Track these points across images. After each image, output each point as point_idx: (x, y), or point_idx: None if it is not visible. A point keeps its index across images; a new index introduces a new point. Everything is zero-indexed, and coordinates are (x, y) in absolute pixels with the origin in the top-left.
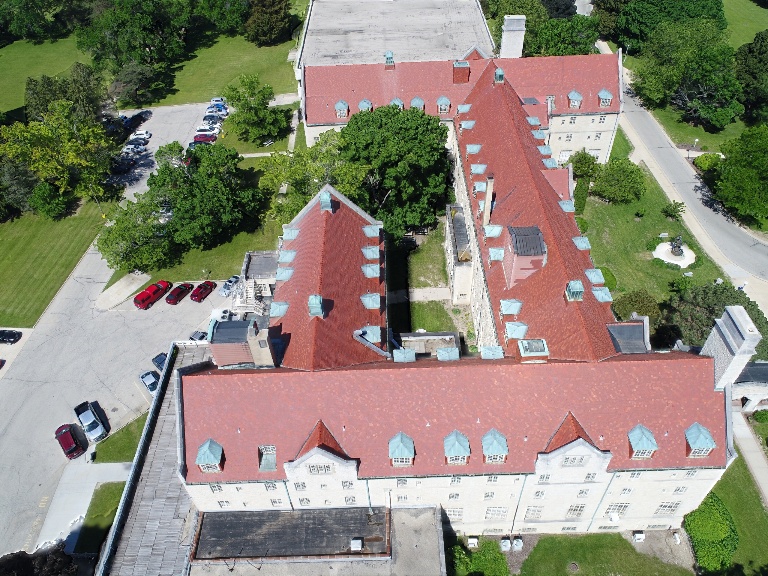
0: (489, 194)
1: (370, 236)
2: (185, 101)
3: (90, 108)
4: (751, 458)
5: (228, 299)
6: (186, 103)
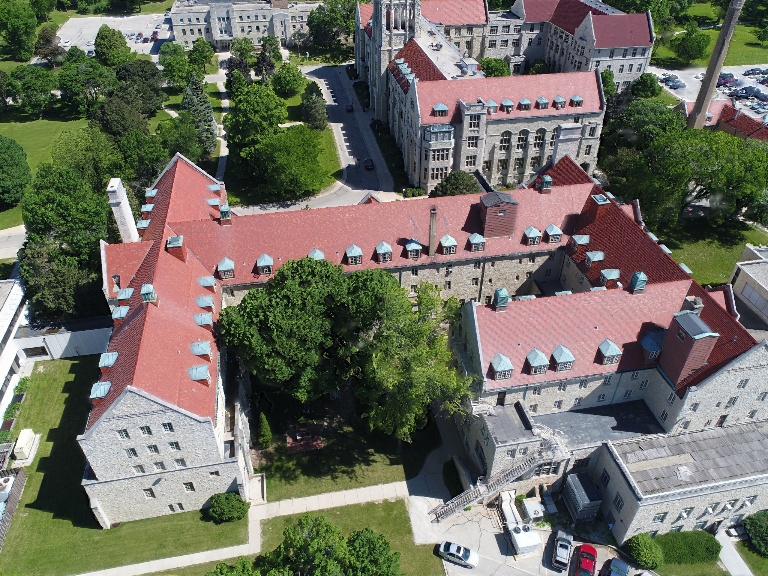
0: None
1: None
2: None
3: None
4: None
5: (479, 554)
6: None
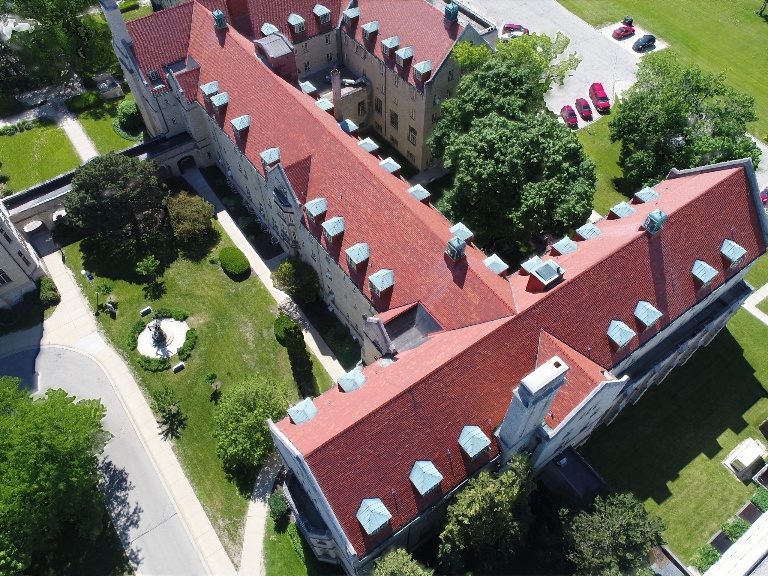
0: None
1: None
2: None
3: None
4: None
5: None
6: None
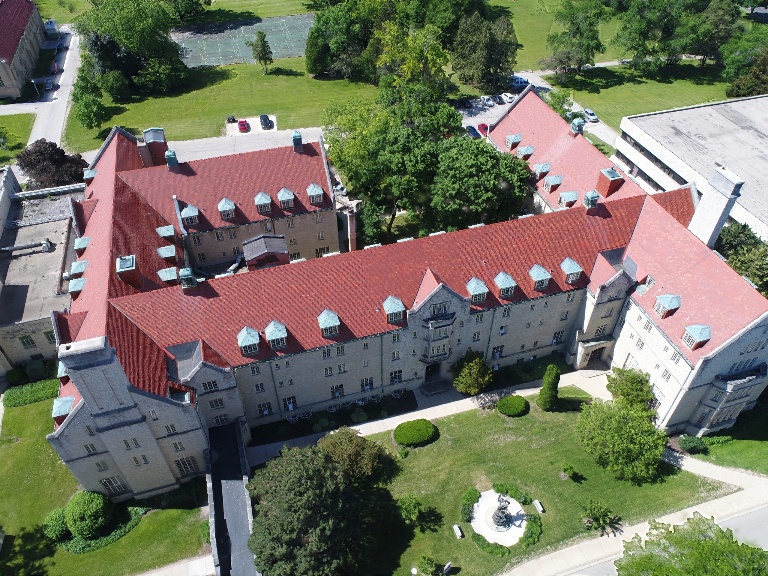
0: None
1: (307, 192)
2: (580, 100)
3: (485, 53)
4: (162, 574)
5: None
6: (576, 101)
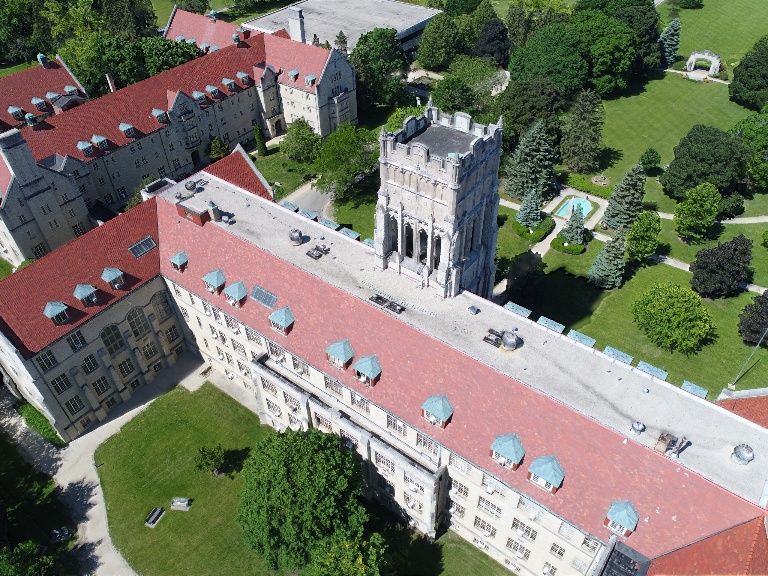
0: (110, 85)
1: None
2: None
3: (131, 14)
4: None
5: None
6: None
